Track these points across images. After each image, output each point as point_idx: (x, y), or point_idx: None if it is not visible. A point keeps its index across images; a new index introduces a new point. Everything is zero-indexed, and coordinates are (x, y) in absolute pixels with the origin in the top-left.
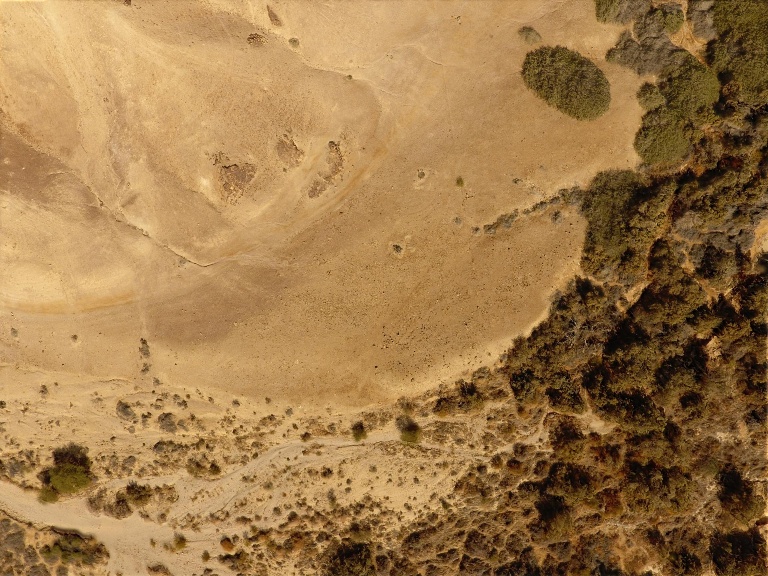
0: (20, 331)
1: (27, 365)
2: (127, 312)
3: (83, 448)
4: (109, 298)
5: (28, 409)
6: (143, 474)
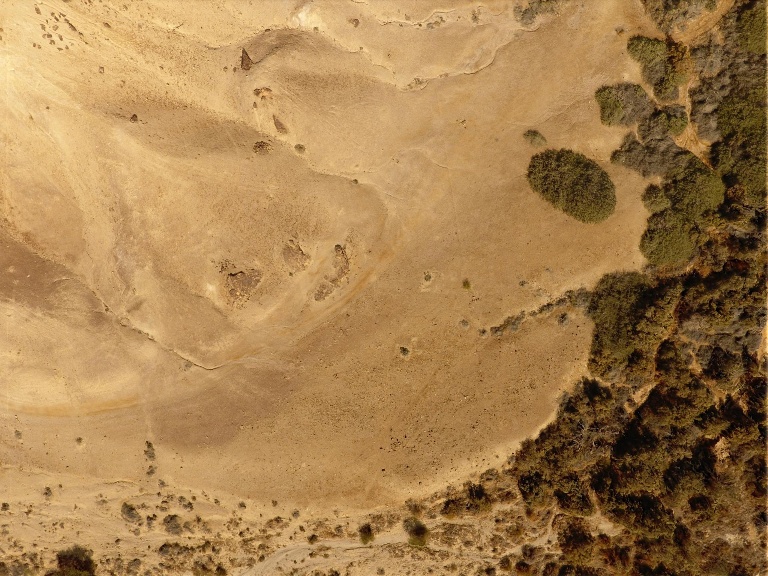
0: (24, 433)
1: (31, 467)
2: (132, 415)
3: (88, 551)
4: (114, 401)
5: (32, 511)
6: None
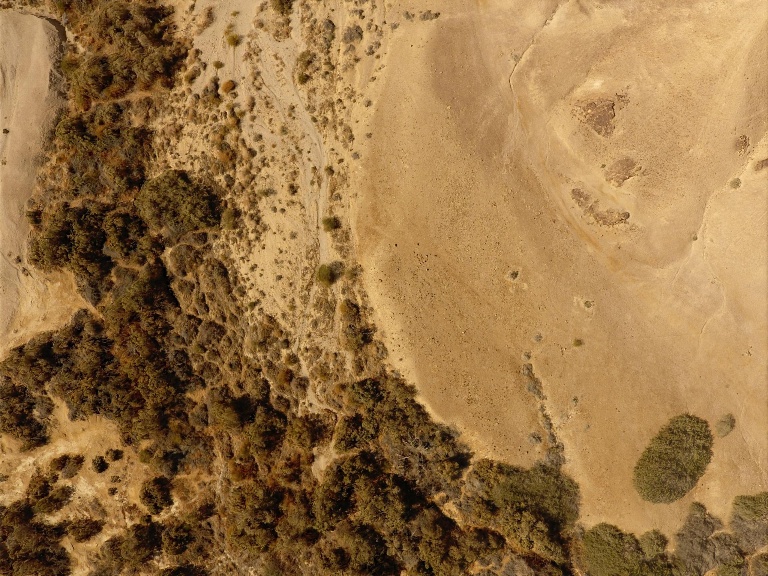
0: None
1: None
2: (468, 0)
3: None
4: None
5: None
6: (304, 8)
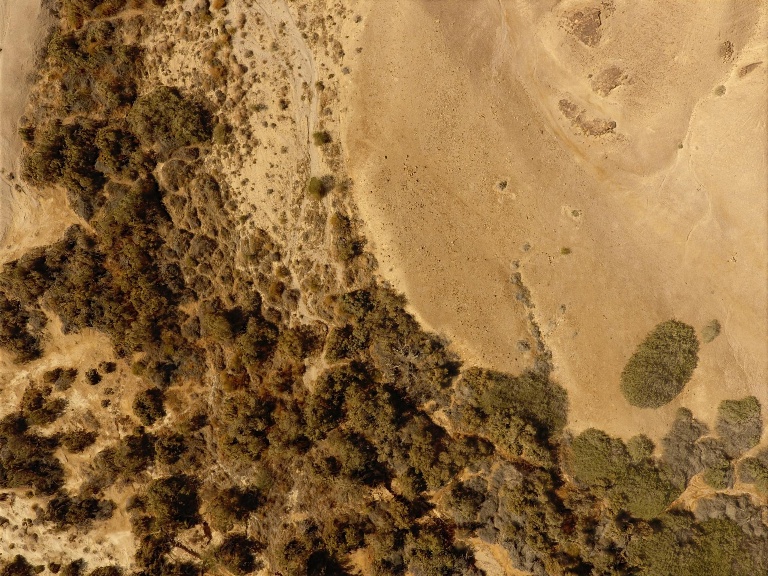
0: None
1: None
2: None
3: None
4: None
5: None
6: None
